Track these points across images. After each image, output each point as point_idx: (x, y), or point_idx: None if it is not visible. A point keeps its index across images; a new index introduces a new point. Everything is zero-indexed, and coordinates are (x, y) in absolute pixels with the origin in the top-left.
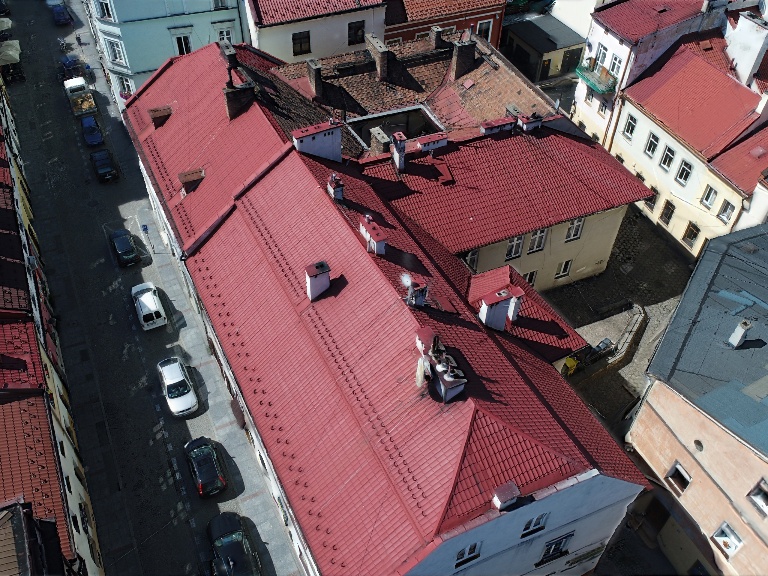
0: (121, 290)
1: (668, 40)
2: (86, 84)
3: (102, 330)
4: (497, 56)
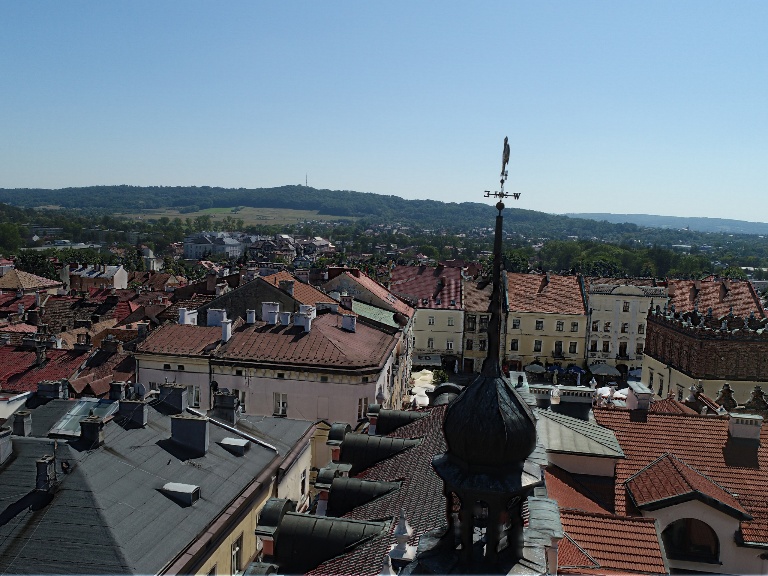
0: None
1: None
2: None
3: None
4: None
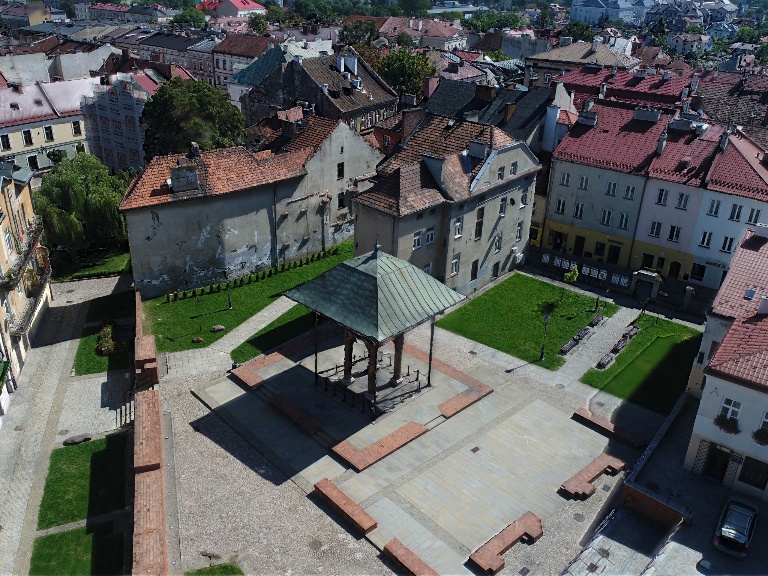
0: None
1: None
2: None
3: None
4: (746, 131)
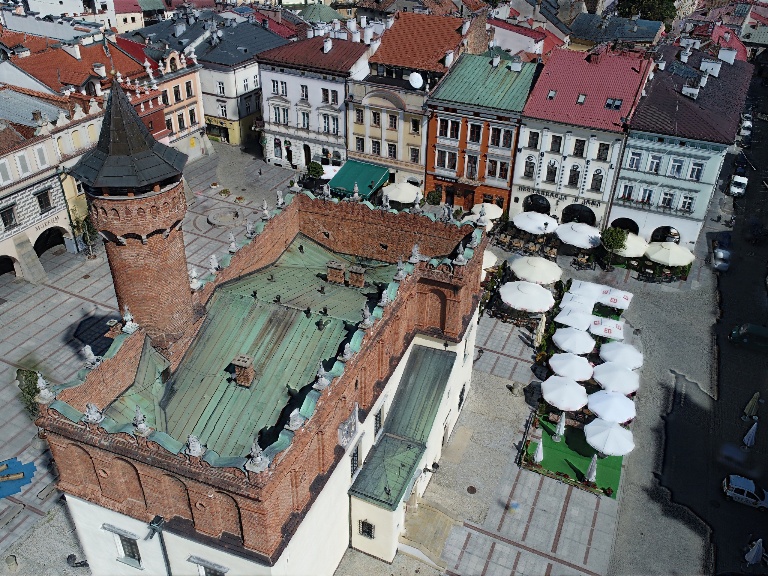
0: (754, 140)
1: None
2: (735, 176)
3: (766, 136)
4: None
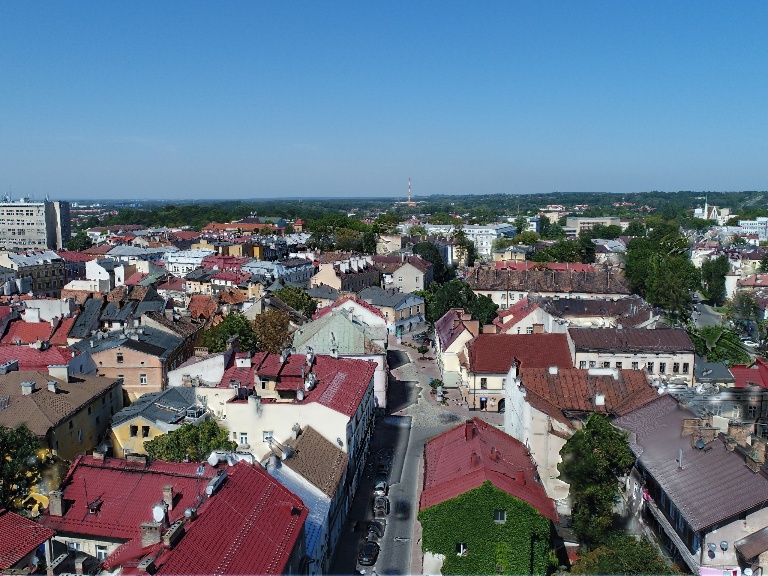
0: None
1: (6, 322)
2: None
3: None
4: None
